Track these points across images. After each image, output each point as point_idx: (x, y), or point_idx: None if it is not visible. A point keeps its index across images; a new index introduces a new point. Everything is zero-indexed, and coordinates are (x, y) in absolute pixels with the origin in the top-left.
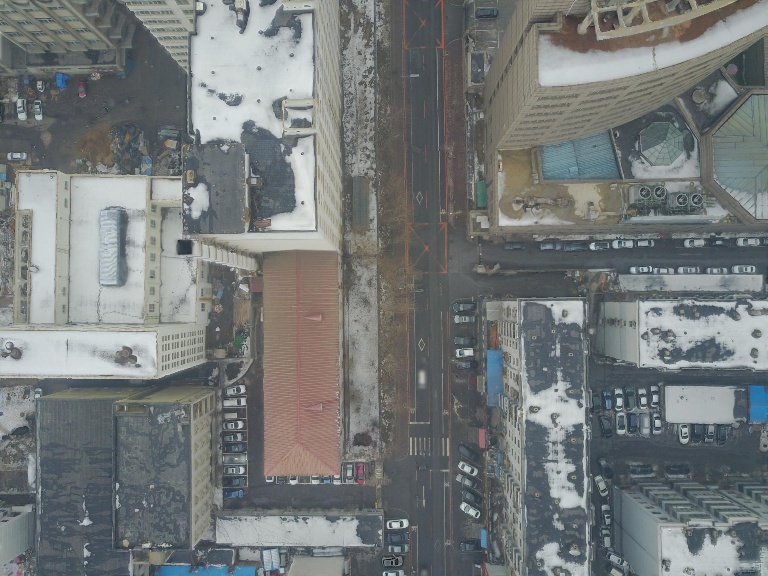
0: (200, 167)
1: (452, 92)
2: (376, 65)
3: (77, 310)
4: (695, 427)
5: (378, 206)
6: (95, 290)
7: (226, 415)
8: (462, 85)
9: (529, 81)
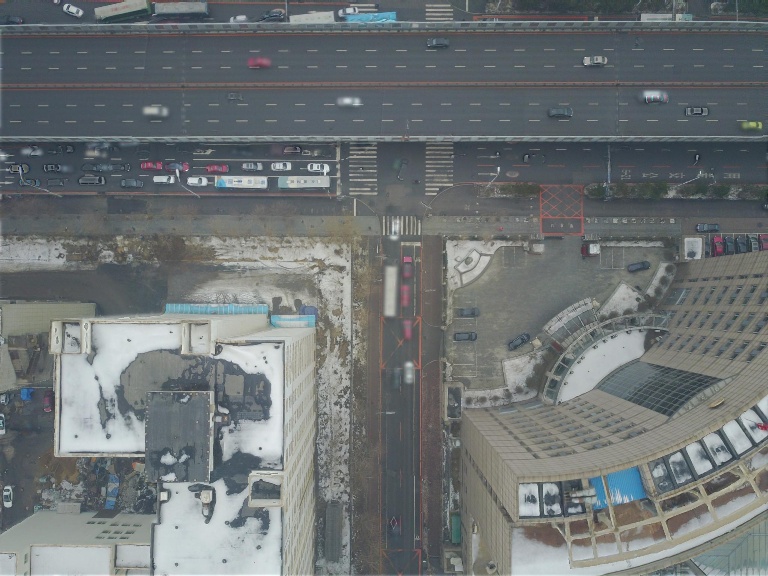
0: None
1: (429, 415)
2: (352, 385)
3: None
4: None
5: (351, 531)
6: None
7: None
8: (439, 408)
9: (502, 566)
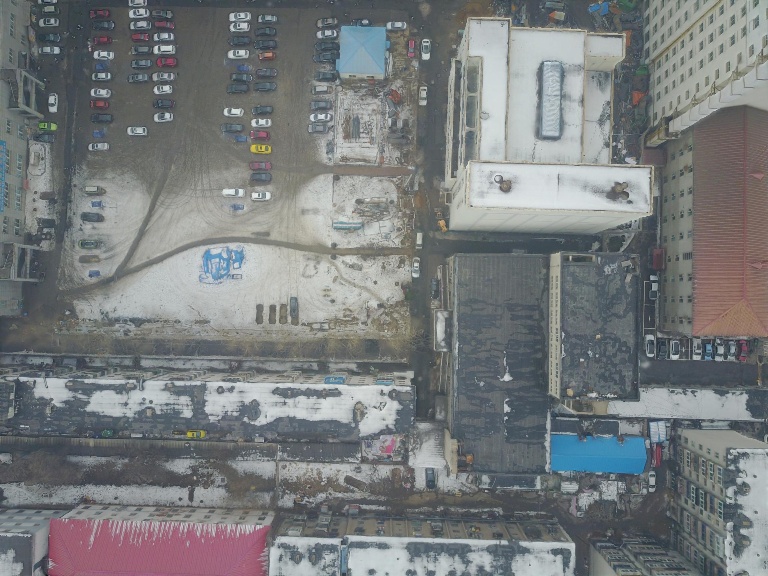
0: None
1: None
2: None
3: None
4: None
5: None
6: (530, 143)
7: None
8: None
9: None
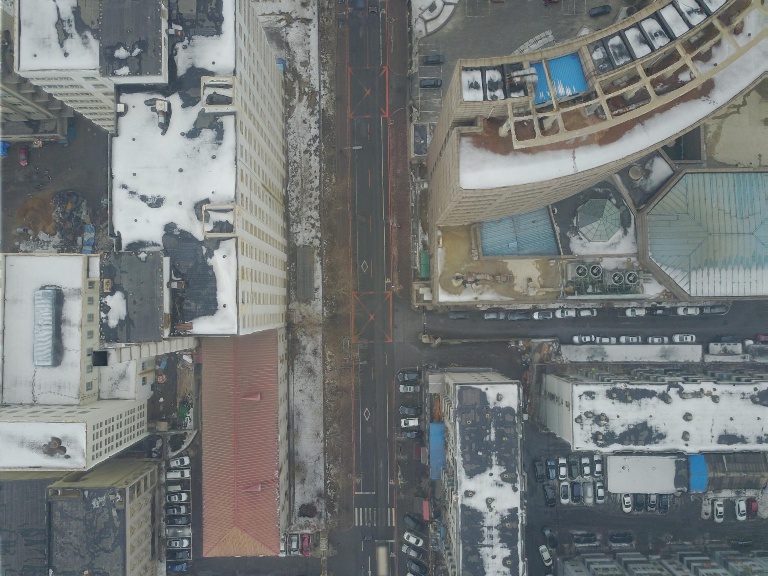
0: (117, 275)
1: (397, 161)
2: (321, 134)
3: (11, 391)
4: (637, 496)
5: (323, 275)
6: (30, 370)
7: (169, 488)
8: (407, 154)
9: (452, 181)
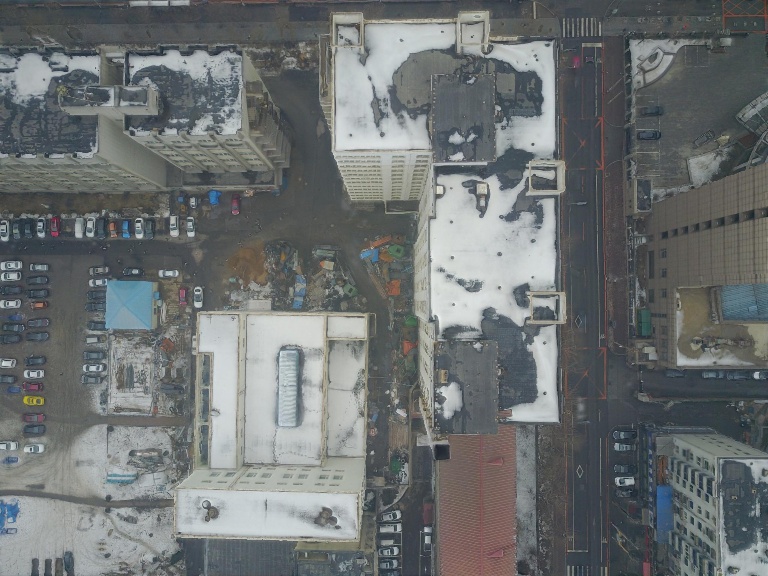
0: (453, 365)
1: (612, 215)
2: None
3: (253, 450)
4: None
5: None
6: (271, 430)
7: (383, 542)
8: (622, 208)
9: None
